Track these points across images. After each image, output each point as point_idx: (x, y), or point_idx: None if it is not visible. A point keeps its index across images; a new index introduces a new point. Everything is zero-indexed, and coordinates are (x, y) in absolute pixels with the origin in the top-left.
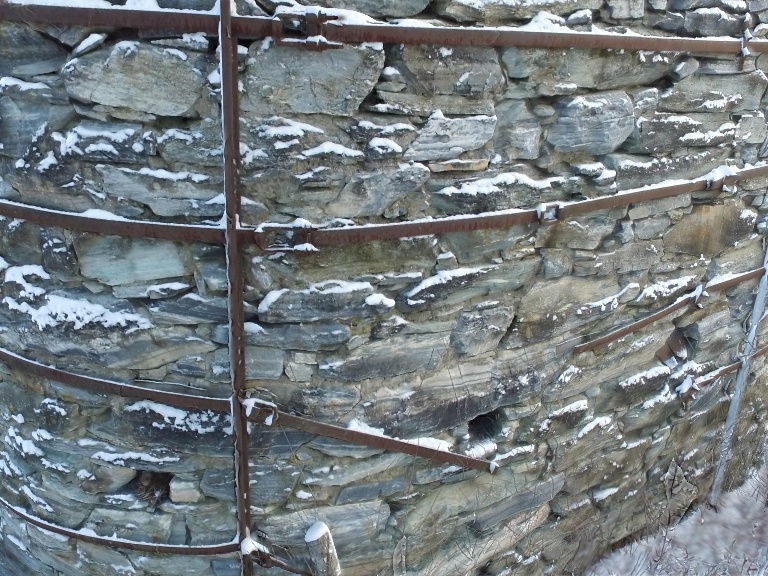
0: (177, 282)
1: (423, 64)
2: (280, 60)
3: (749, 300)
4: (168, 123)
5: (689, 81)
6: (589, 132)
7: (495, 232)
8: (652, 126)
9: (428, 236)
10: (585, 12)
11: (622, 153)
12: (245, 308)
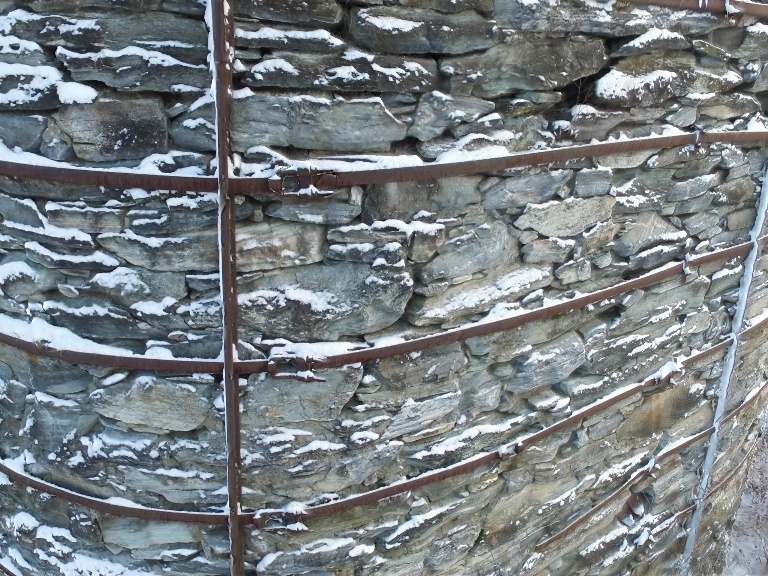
0: (187, 549)
1: (396, 369)
2: (274, 386)
3: (701, 453)
4: (180, 433)
5: (636, 305)
6: (544, 376)
7: (462, 476)
8: (602, 353)
9: (403, 493)
10: (537, 292)
11: (576, 377)
12: (245, 567)
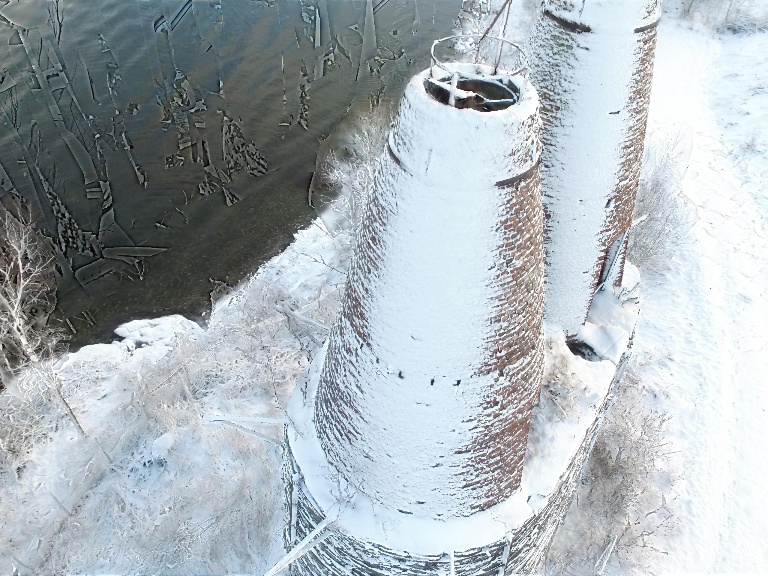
0: None
1: None
2: None
3: None
4: None
5: None
6: None
7: None
8: None
9: None
10: None
11: None
12: None
